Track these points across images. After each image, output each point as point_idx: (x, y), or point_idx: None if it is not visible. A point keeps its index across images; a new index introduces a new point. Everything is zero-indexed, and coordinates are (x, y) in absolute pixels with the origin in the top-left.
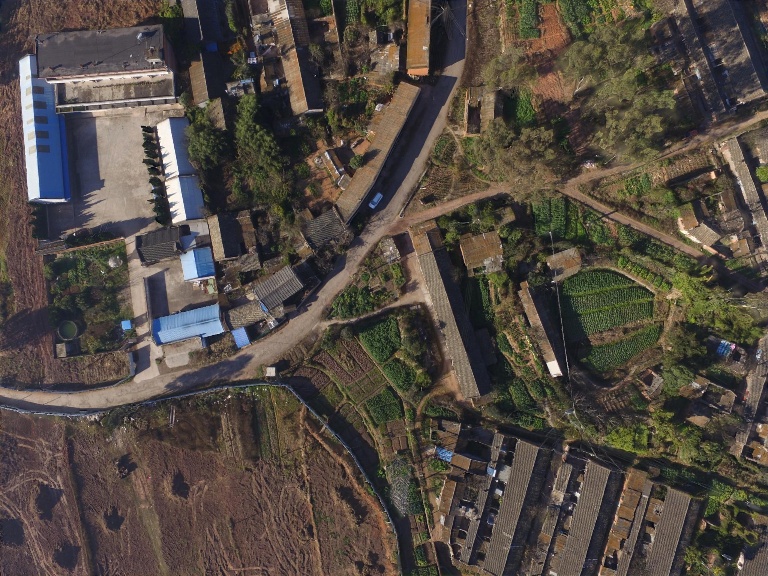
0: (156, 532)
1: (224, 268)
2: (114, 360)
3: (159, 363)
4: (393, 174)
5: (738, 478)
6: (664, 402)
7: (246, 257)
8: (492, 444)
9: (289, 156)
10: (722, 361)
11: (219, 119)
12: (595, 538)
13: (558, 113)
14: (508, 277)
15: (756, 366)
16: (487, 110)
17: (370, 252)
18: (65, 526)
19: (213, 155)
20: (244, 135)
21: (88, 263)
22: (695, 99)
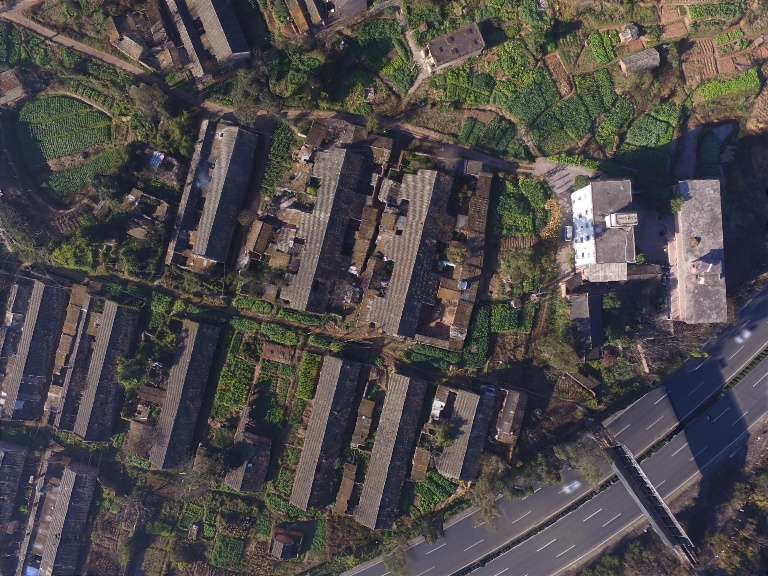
0: None
1: None
2: None
3: None
4: None
5: (179, 289)
6: (110, 219)
7: None
8: None
9: None
10: (149, 170)
11: None
12: (36, 354)
13: None
14: None
15: (187, 175)
16: None
17: None
18: None
19: None
20: None
21: None
22: None
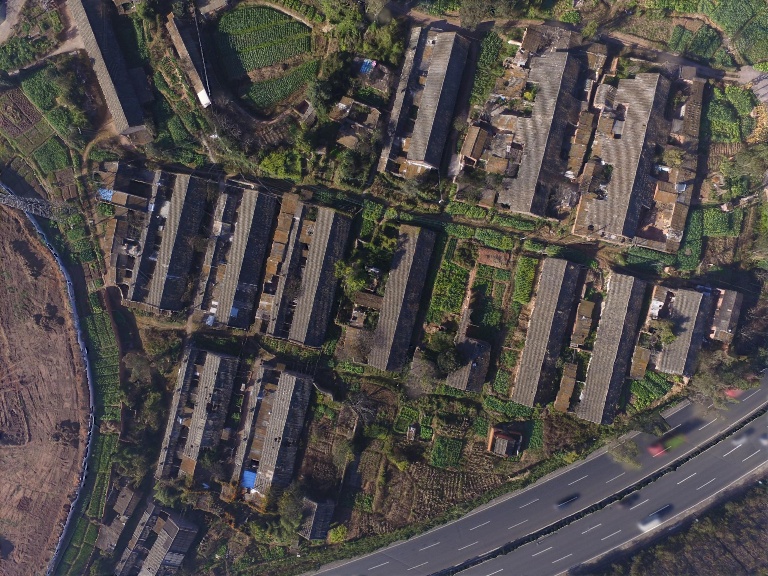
0: None
1: None
2: None
3: None
4: None
5: (390, 197)
6: (317, 128)
7: None
8: (153, 182)
9: None
10: (362, 77)
11: None
12: (249, 262)
13: None
14: (146, 4)
15: (398, 83)
16: None
17: (28, 1)
18: None
19: None
20: None
21: None
22: None
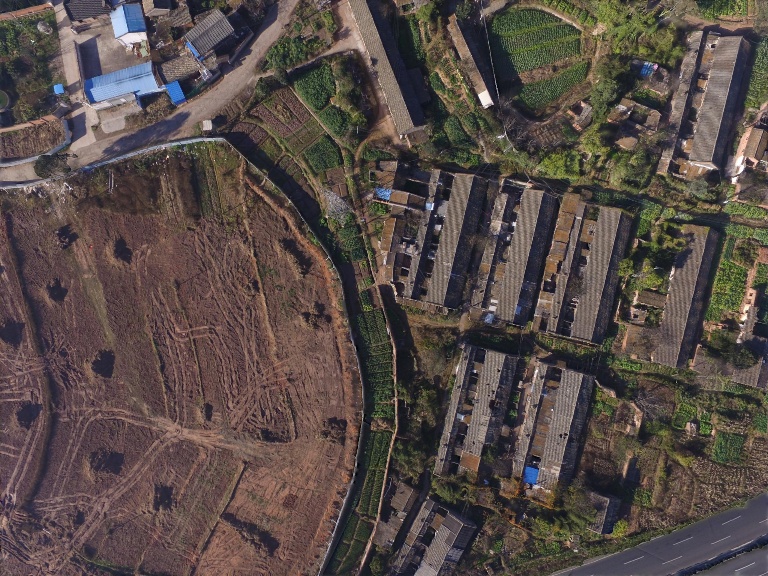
0: (101, 301)
1: (155, 23)
2: (49, 130)
3: (95, 129)
4: None
5: (667, 197)
6: None
7: (177, 11)
8: (429, 181)
9: None
10: (646, 80)
11: None
12: (532, 260)
13: None
14: (435, 5)
15: (678, 85)
16: None
17: (301, 1)
18: (7, 303)
19: None
20: None
21: (17, 33)
22: None
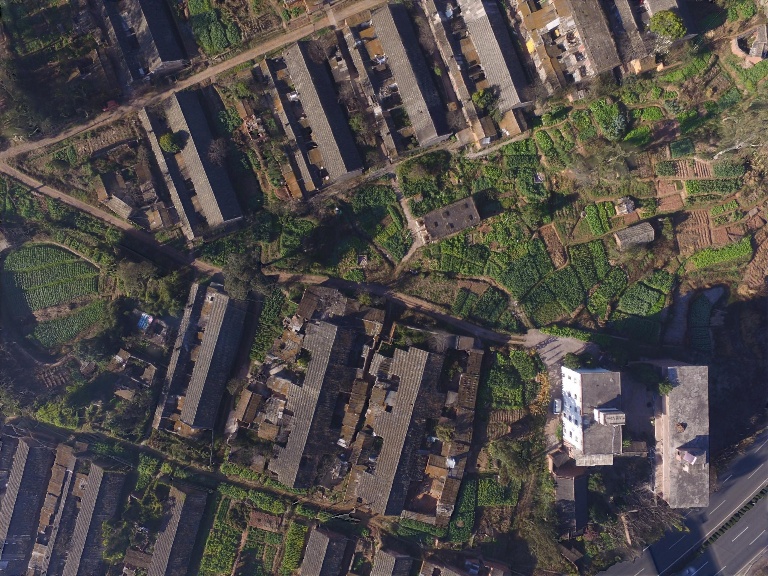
0: None
1: None
2: None
3: None
4: None
5: (166, 451)
6: (97, 377)
7: None
8: None
9: None
10: (137, 334)
11: None
12: (20, 514)
13: None
14: None
15: (176, 338)
16: None
17: None
18: None
19: None
20: None
21: None
22: (110, 69)
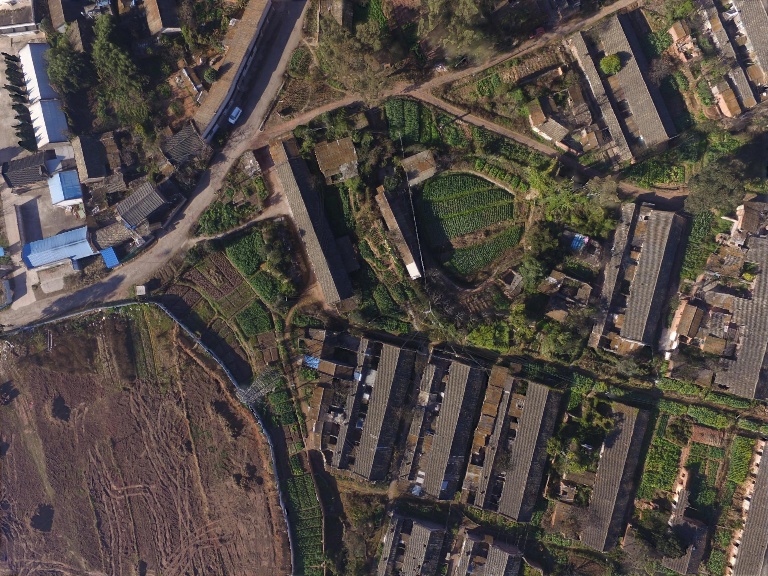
0: (40, 456)
1: (90, 190)
2: None
3: (35, 289)
4: (252, 89)
5: (598, 370)
6: (524, 299)
7: (111, 178)
8: (358, 350)
9: (148, 76)
10: (575, 254)
11: (77, 42)
12: (459, 435)
13: (408, 19)
14: (361, 180)
15: (610, 258)
16: (336, 18)
17: (233, 167)
18: None
19: (72, 77)
20: (99, 54)
21: None
22: None
